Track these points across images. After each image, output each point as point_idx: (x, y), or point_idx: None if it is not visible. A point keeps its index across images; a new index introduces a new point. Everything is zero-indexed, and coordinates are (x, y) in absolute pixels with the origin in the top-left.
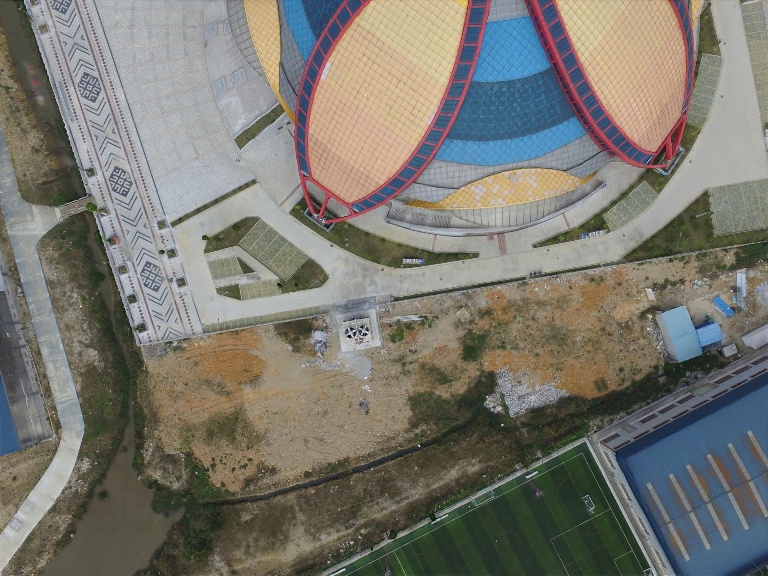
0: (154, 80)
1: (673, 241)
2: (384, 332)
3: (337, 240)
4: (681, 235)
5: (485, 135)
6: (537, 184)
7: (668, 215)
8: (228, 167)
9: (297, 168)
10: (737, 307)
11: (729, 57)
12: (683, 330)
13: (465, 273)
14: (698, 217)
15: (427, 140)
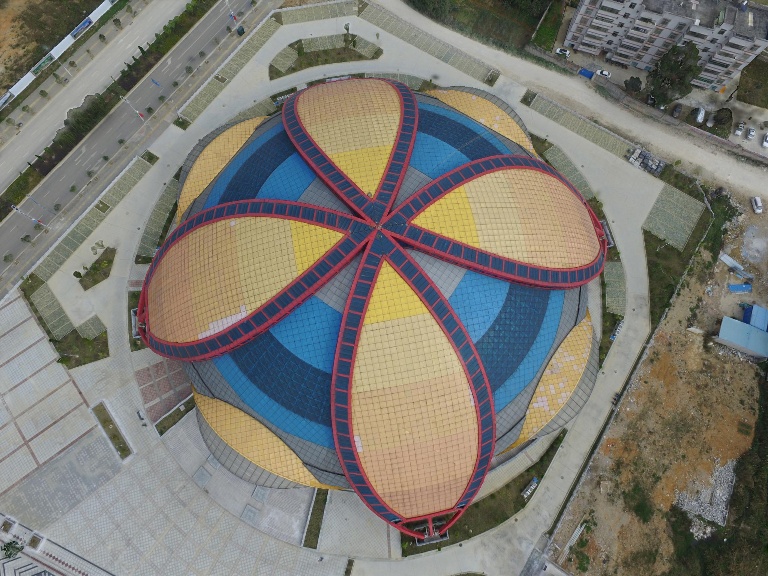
0: (188, 567)
1: (672, 287)
2: (571, 571)
3: (460, 536)
4: (664, 272)
5: (512, 367)
6: (572, 356)
7: (641, 268)
8: (318, 573)
9: (372, 512)
10: (747, 280)
11: (559, 141)
12: (744, 334)
13: (572, 453)
14: (659, 250)
15: (482, 416)
